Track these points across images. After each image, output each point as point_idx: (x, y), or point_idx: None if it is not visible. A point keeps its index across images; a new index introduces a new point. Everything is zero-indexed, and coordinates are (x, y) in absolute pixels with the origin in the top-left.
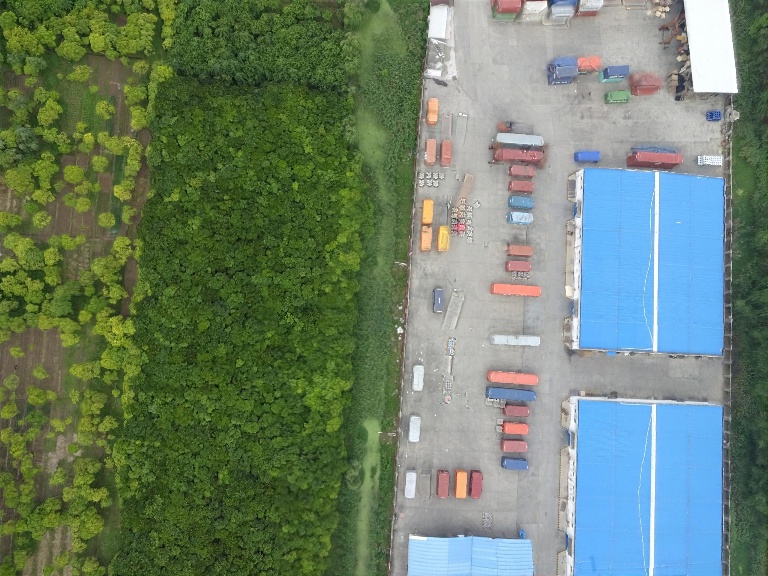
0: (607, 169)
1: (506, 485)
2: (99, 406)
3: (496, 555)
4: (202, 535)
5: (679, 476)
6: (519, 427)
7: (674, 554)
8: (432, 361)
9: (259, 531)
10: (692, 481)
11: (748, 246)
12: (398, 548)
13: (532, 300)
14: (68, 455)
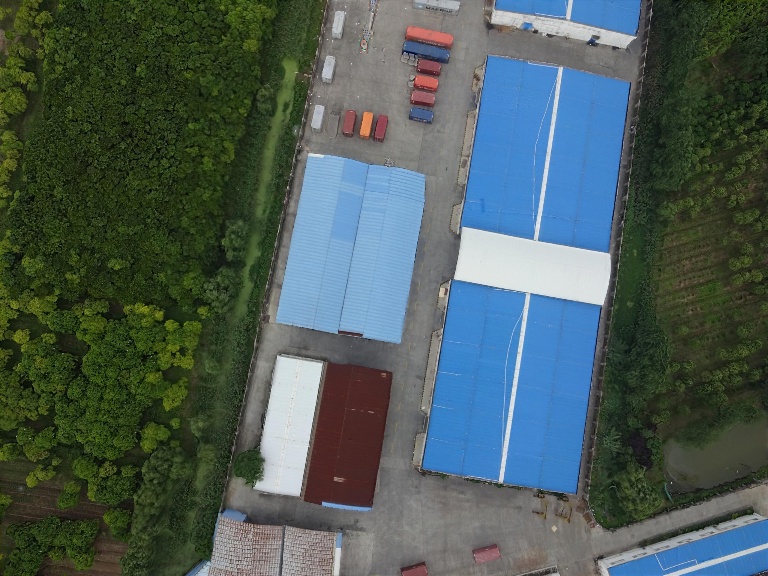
0: None
1: (411, 137)
2: None
3: (389, 181)
4: (113, 115)
5: (578, 137)
6: (429, 80)
7: (564, 208)
8: (355, 15)
9: (166, 120)
10: (591, 145)
11: None
12: (300, 178)
13: None
14: (6, 49)
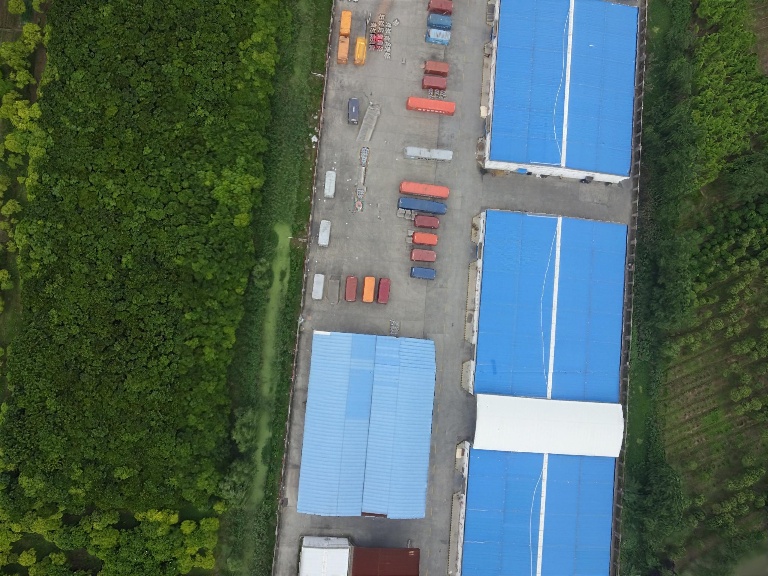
0: None
1: (414, 295)
2: (2, 188)
3: (399, 353)
4: (102, 315)
5: (582, 287)
6: (428, 236)
7: (573, 361)
8: (345, 171)
9: (161, 314)
10: (594, 293)
11: (660, 79)
12: (305, 350)
13: (447, 118)
14: None
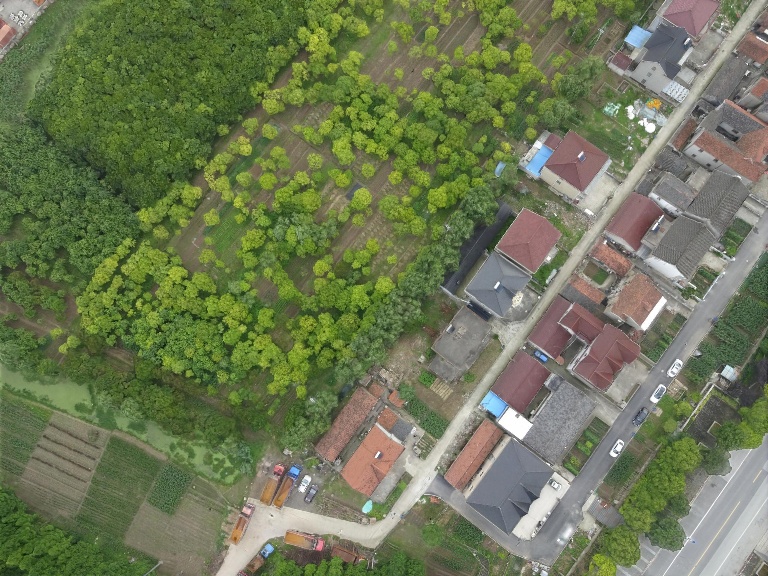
0: None
1: None
2: None
3: None
4: None
5: None
6: None
7: None
8: None
9: None
10: None
11: None
12: None
13: None
14: None
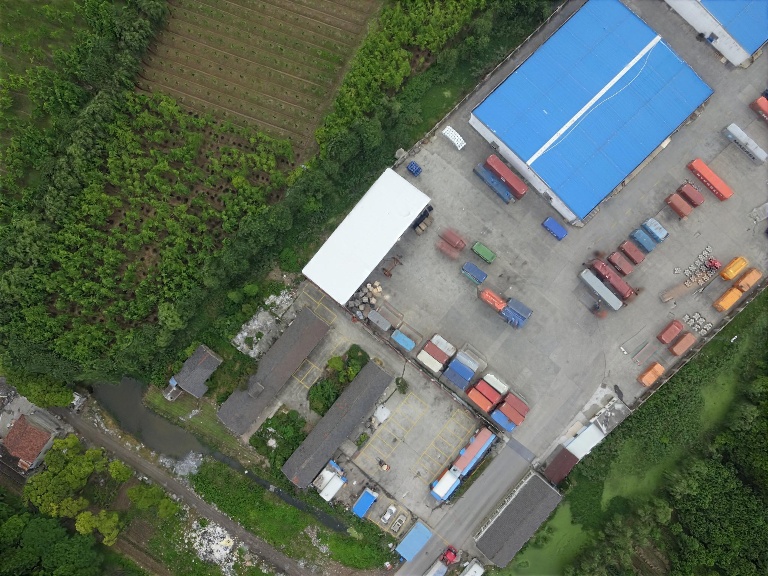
0: (565, 203)
1: None
2: None
3: None
4: None
5: None
6: None
7: None
8: None
9: None
10: None
11: None
12: None
13: None
14: None
